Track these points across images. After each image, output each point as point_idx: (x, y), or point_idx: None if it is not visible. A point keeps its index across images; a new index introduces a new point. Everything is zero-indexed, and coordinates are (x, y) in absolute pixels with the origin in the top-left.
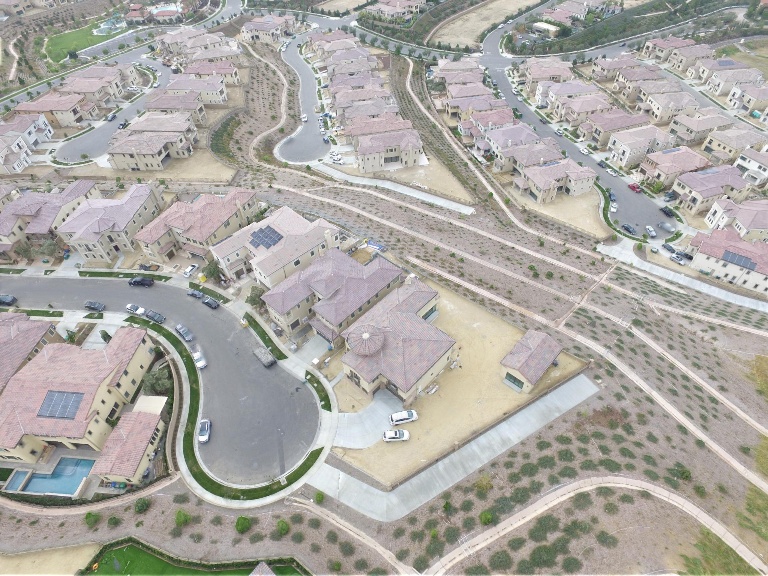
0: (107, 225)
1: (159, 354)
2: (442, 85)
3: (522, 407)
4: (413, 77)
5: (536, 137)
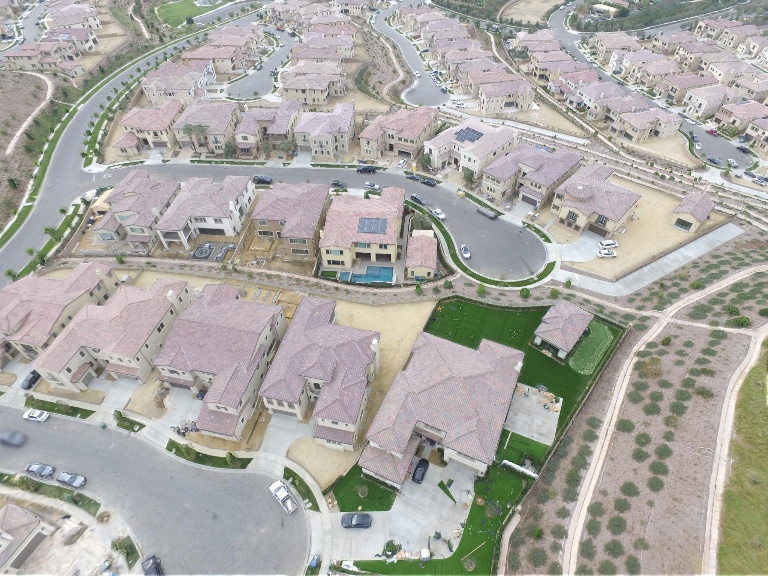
0: (336, 127)
1: (407, 211)
2: (525, 53)
3: (692, 240)
4: (497, 46)
5: (623, 92)
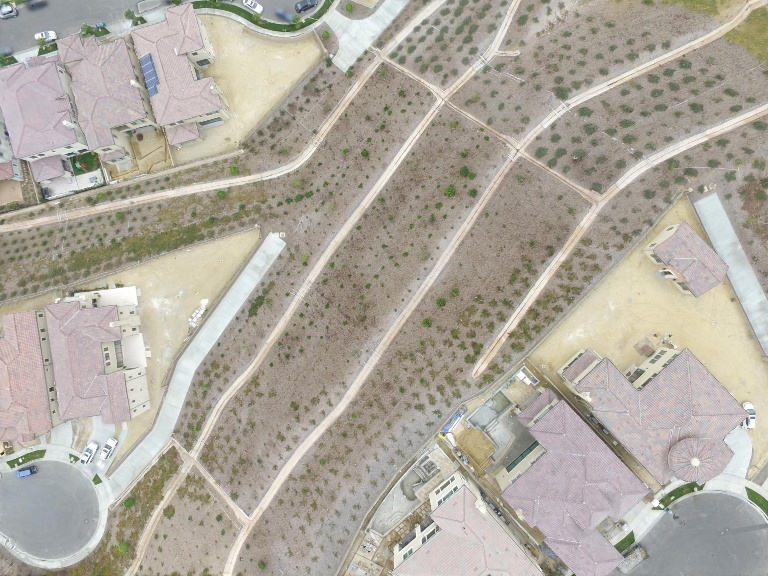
0: None
1: None
2: None
3: None
4: None
5: (50, 69)
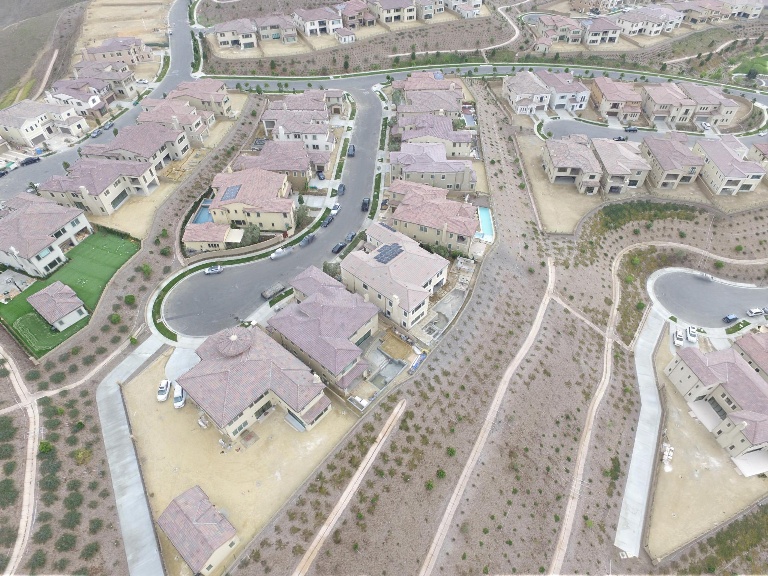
0: (405, 161)
1: None
2: None
3: None
4: None
5: None
